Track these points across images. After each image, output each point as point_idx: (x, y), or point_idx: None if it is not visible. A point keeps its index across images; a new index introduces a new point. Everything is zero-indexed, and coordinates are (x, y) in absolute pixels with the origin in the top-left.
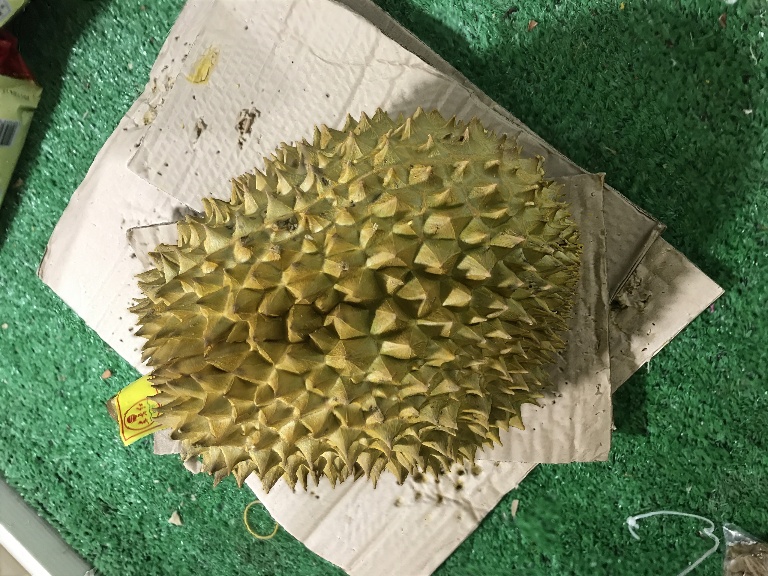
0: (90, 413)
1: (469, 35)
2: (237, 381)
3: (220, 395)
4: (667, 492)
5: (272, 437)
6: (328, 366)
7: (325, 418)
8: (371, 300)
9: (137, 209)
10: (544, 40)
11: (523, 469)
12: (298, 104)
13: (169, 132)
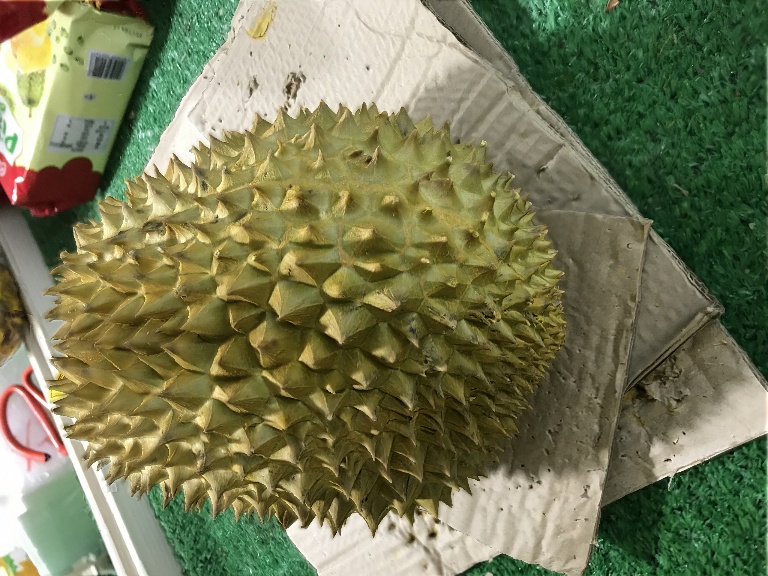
0: None
1: (536, 10)
2: None
3: None
4: None
5: (117, 447)
6: None
7: (155, 448)
8: (210, 335)
9: None
10: (624, 26)
11: None
12: (340, 74)
13: (226, 87)
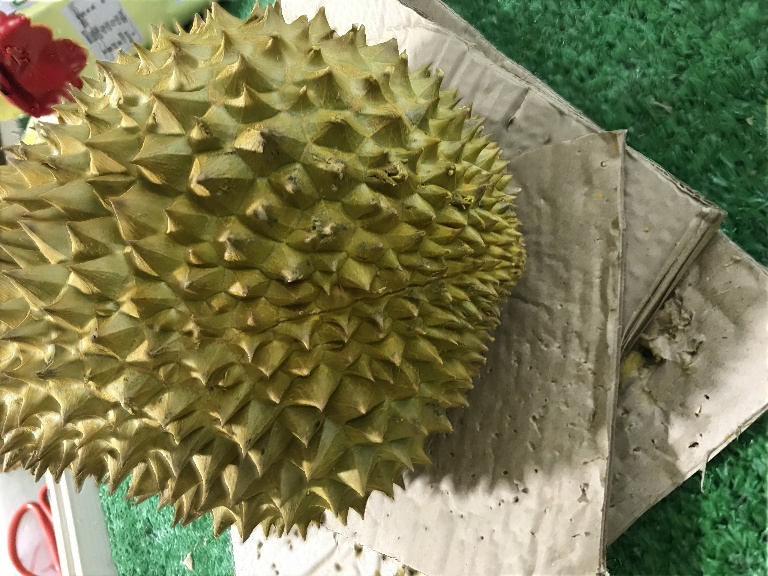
0: None
1: None
2: None
3: None
4: None
5: None
6: None
7: (8, 363)
8: (74, 210)
9: None
10: None
11: None
12: None
13: None
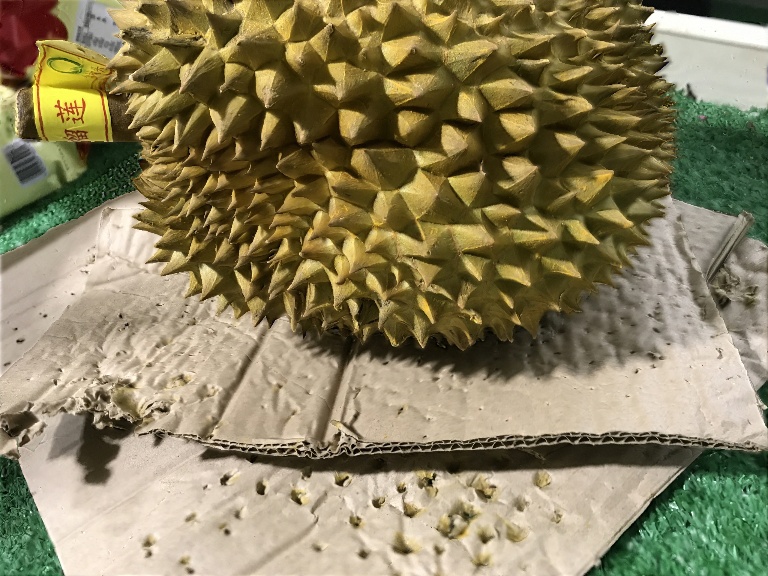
0: None
1: None
2: None
3: None
4: None
5: None
6: None
7: None
8: None
9: None
10: None
11: (607, 527)
12: None
13: None
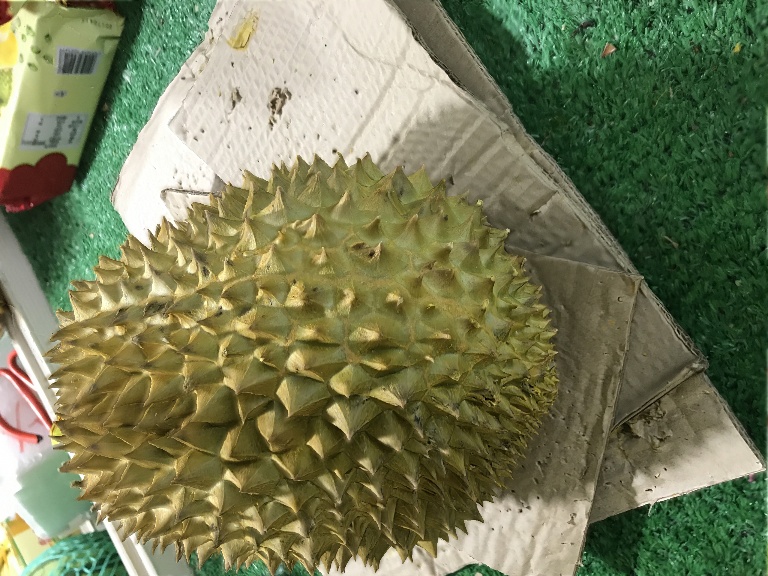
0: None
1: (530, 46)
2: None
3: None
4: None
5: (130, 511)
6: None
7: (168, 519)
8: (219, 424)
9: (187, 163)
10: (620, 73)
11: None
12: (328, 94)
13: (207, 97)
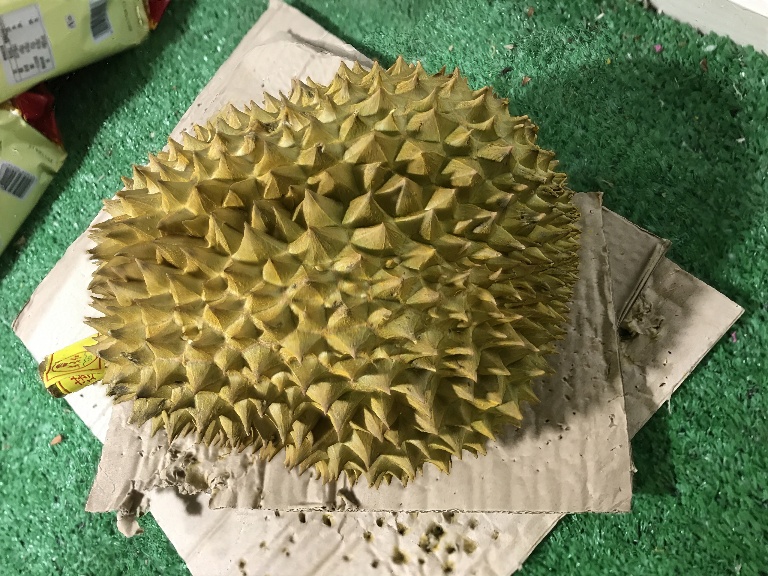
0: (26, 489)
1: None
2: (186, 275)
3: (165, 293)
4: (711, 574)
5: (215, 338)
6: (291, 254)
7: (280, 310)
8: (345, 186)
9: None
10: (537, 93)
11: (527, 542)
12: None
13: None
